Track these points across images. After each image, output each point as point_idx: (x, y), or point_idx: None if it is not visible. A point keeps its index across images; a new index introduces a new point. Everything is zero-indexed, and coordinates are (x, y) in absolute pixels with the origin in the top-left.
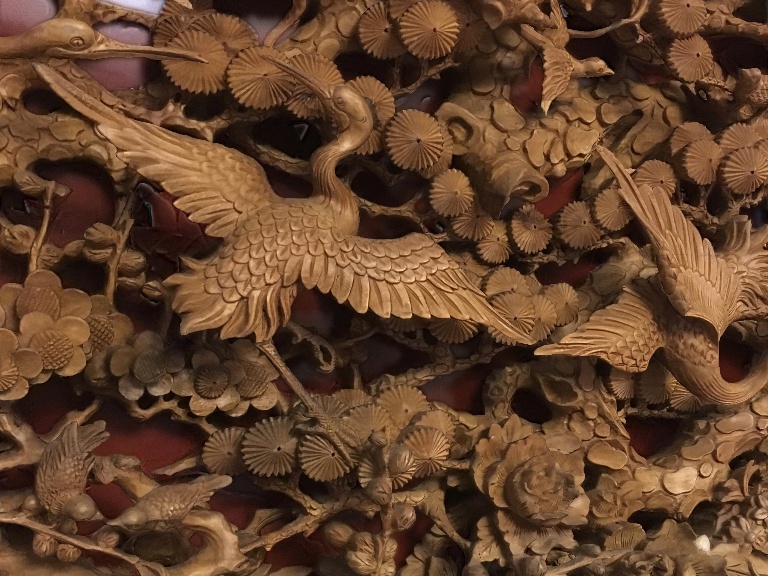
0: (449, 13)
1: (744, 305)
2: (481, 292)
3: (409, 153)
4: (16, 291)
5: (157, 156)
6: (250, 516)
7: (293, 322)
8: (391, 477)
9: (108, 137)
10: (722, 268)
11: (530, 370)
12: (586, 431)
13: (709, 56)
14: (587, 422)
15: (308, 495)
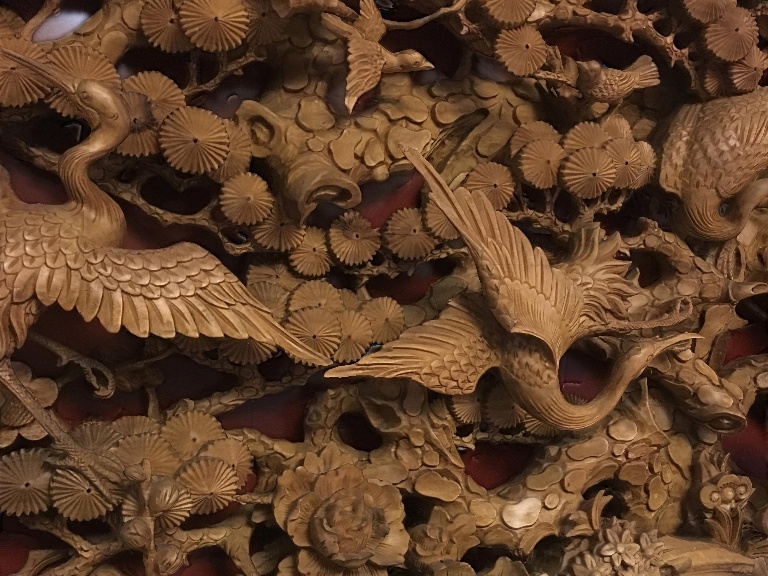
0: (235, 1)
1: (590, 320)
2: (265, 308)
3: (186, 154)
4: None
5: None
6: (23, 558)
7: (56, 342)
8: (152, 516)
9: None
10: (558, 279)
11: (358, 392)
12: (413, 459)
13: (542, 48)
14: (414, 450)
15: (79, 535)
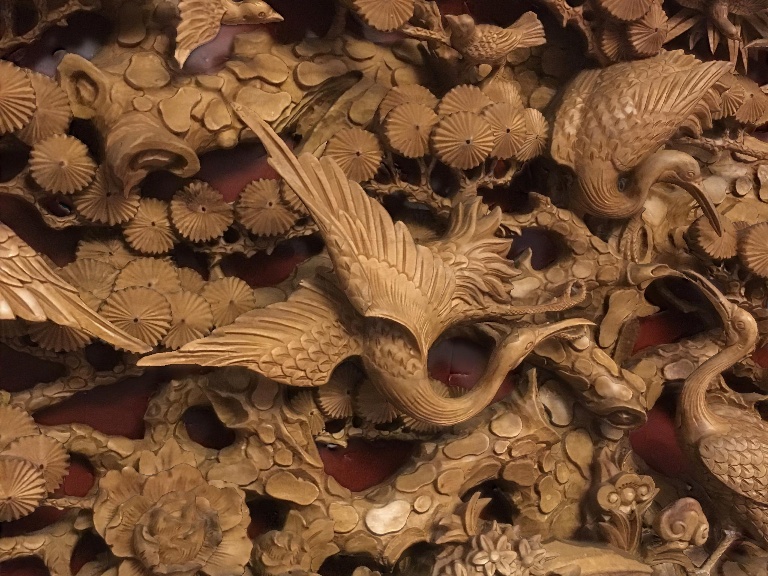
0: None
1: (465, 303)
2: (70, 286)
3: None
4: None
5: None
6: None
7: None
8: None
9: None
10: (424, 258)
11: (208, 384)
12: (264, 458)
13: None
14: (265, 447)
15: None
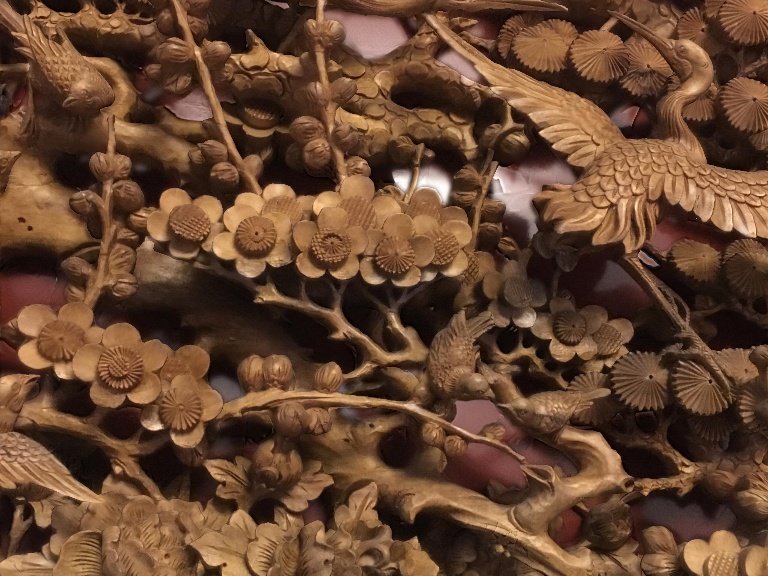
0: (765, 2)
1: None
2: None
3: (745, 113)
4: (403, 207)
5: (524, 92)
6: None
7: (647, 269)
8: None
9: (483, 74)
10: None
11: None
12: None
13: None
14: None
15: (678, 451)
